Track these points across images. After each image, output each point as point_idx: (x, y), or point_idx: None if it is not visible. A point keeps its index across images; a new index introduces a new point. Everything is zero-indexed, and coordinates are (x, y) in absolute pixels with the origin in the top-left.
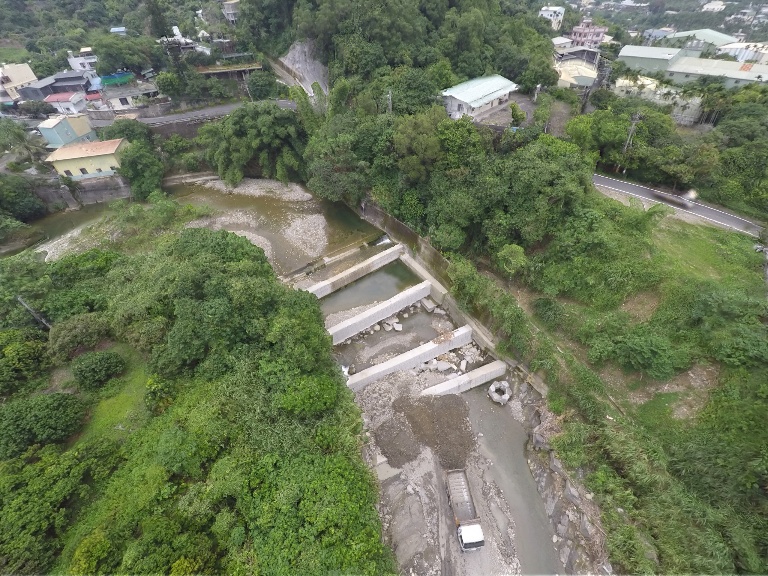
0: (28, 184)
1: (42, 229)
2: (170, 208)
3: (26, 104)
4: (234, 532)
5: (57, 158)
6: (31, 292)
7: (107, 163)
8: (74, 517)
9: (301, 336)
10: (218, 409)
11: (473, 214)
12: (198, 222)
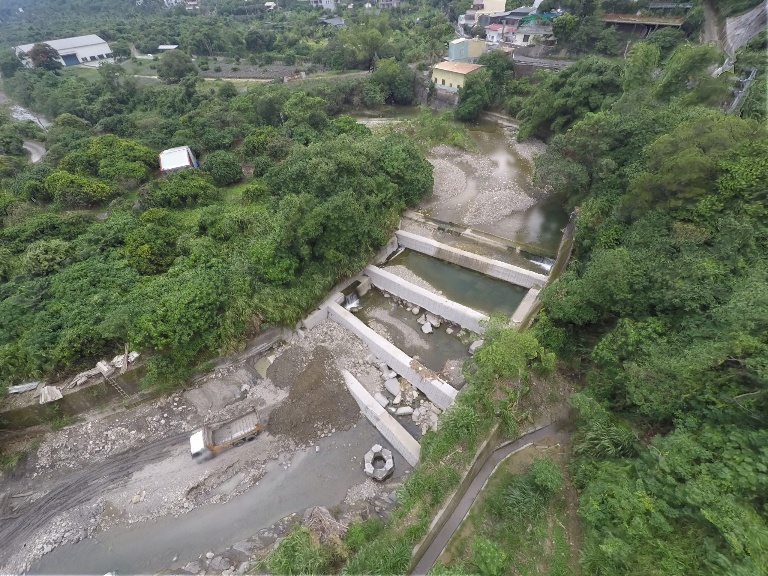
0: (413, 79)
1: (394, 110)
2: (444, 127)
3: (475, 27)
4: (172, 267)
5: (438, 67)
6: (295, 116)
7: (458, 81)
8: (182, 207)
9: (294, 218)
10: (241, 219)
11: (616, 293)
12: (451, 149)
